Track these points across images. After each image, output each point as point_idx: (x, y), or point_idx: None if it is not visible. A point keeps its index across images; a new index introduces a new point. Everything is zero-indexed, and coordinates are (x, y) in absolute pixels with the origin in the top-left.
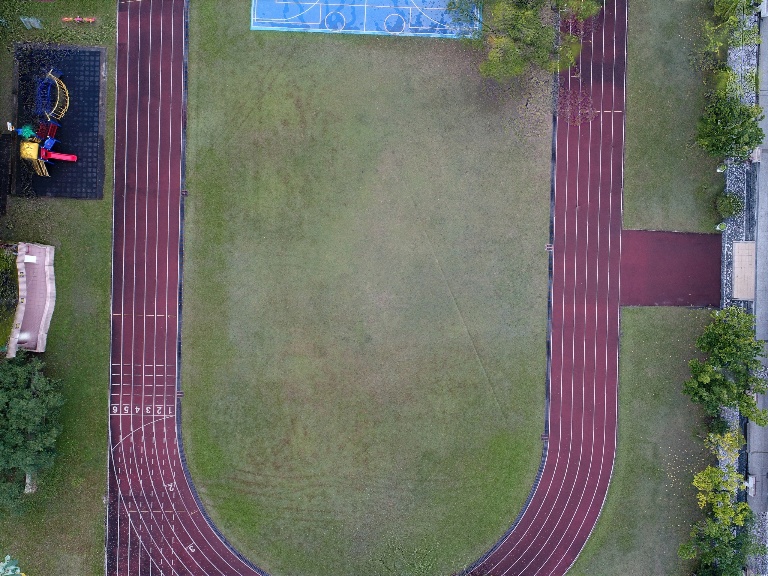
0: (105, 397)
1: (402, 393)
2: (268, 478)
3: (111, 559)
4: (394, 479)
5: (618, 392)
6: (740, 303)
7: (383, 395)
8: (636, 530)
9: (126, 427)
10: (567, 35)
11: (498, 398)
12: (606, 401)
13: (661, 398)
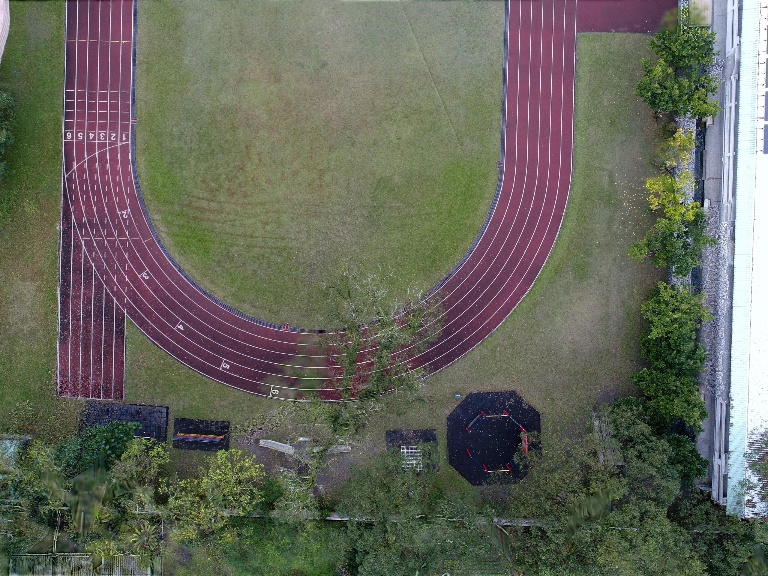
0: (59, 123)
1: (357, 119)
2: (222, 204)
3: (64, 286)
4: (349, 206)
5: (574, 119)
6: (697, 30)
7: (338, 121)
8: (591, 258)
9: (80, 153)
10: None
11: (454, 125)
12: (562, 128)
13: (617, 125)
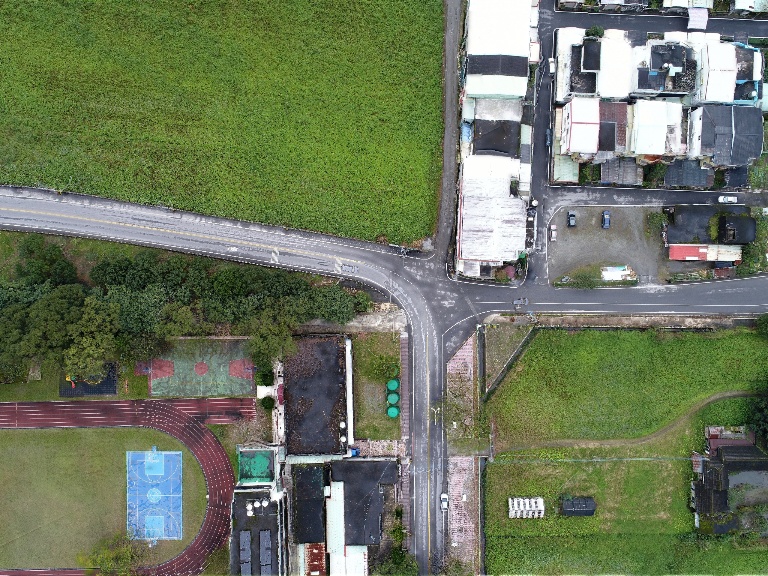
0: None
1: None
2: None
3: None
4: None
5: None
6: None
7: None
8: None
9: None
10: (130, 572)
11: None
12: None
13: None
